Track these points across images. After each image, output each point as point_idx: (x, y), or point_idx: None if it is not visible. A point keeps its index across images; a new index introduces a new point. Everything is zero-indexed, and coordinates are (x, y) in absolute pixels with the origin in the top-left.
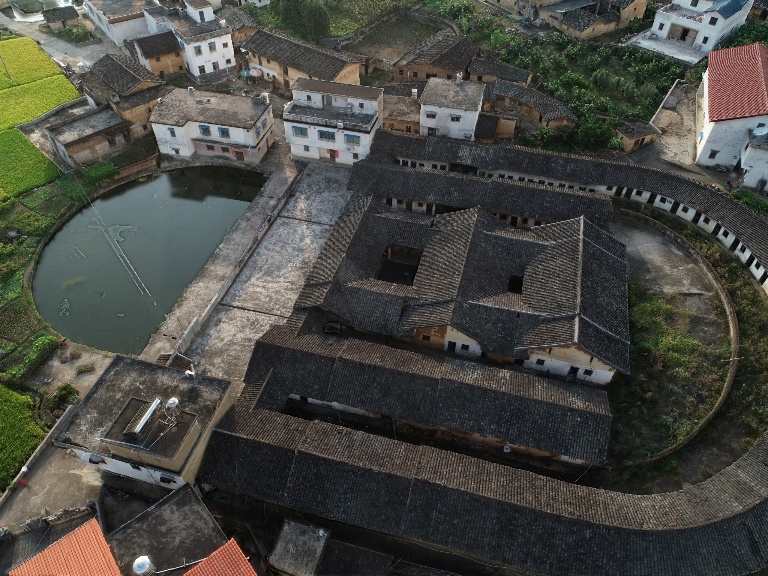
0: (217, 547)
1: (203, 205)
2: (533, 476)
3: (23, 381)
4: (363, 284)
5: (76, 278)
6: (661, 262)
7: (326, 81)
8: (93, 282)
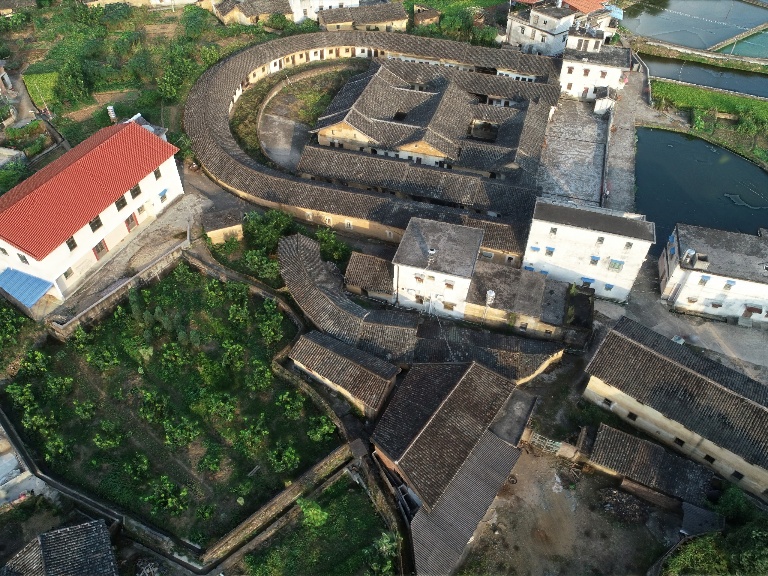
0: (538, 10)
1: (681, 221)
2: (414, 53)
3: (691, 113)
4: (507, 114)
5: (729, 167)
6: (282, 140)
7: (614, 233)
8: (713, 166)
